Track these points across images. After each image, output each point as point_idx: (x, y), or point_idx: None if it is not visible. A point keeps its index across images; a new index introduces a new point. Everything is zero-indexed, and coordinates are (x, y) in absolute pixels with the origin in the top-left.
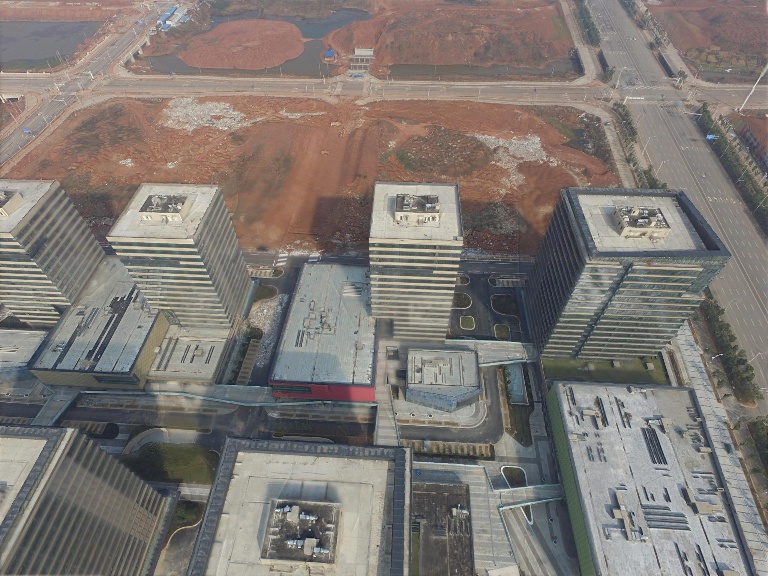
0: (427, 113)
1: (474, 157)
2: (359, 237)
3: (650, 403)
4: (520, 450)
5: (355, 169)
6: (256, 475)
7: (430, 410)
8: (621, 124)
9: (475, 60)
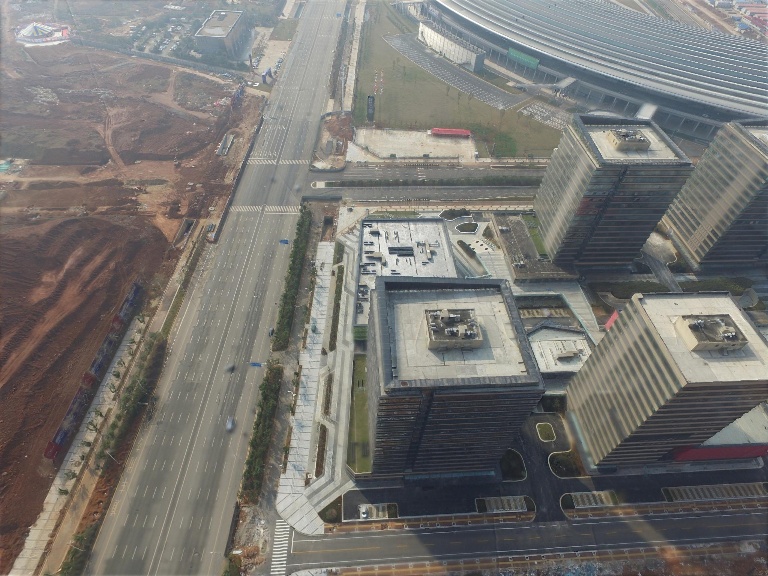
0: None
1: None
2: None
3: None
4: None
5: None
6: None
7: None
8: None
9: None
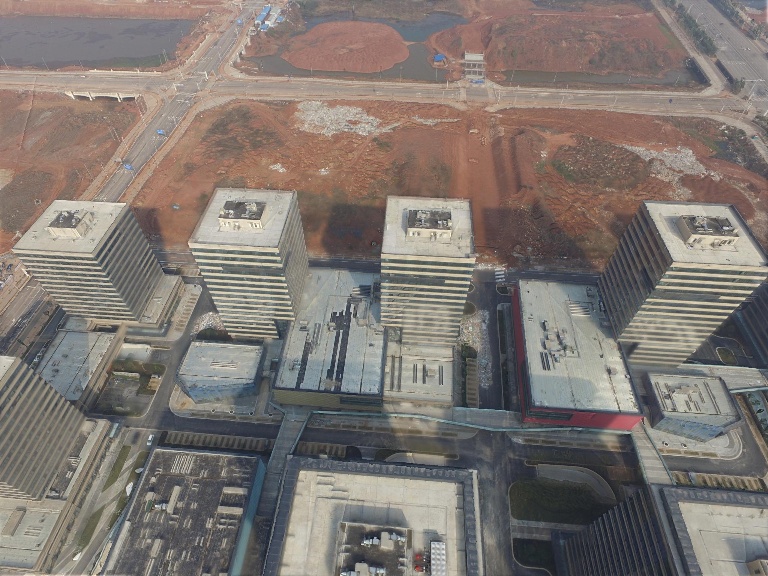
0: (565, 122)
1: (636, 169)
2: (540, 251)
3: None
4: None
5: (515, 179)
6: (706, 529)
7: (681, 439)
8: None
9: (590, 67)
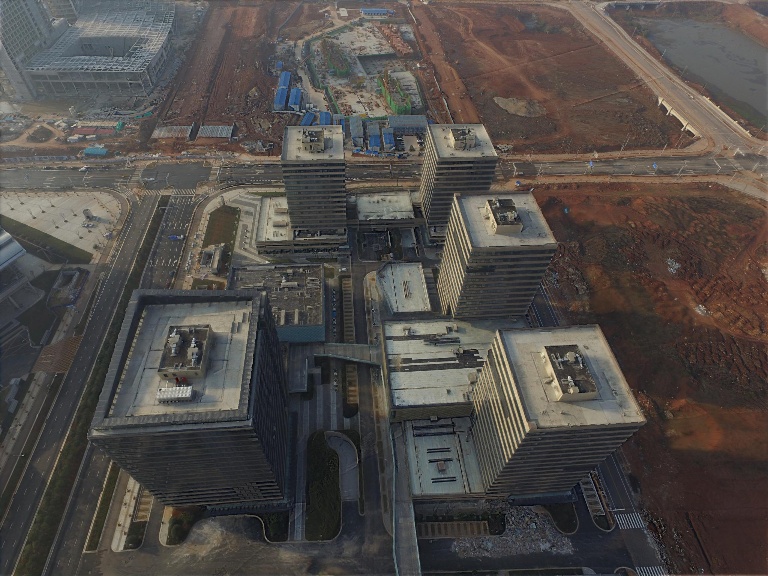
0: None
1: None
2: None
3: None
4: None
5: None
6: None
7: None
8: None
9: None
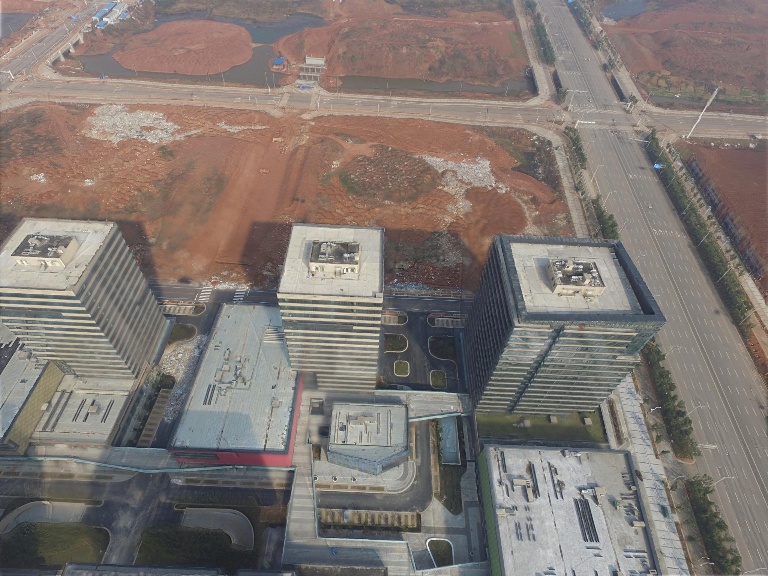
0: (375, 131)
1: (420, 181)
2: None
3: (584, 469)
4: (449, 519)
5: (293, 191)
6: None
7: (354, 472)
8: (571, 150)
9: (430, 75)
